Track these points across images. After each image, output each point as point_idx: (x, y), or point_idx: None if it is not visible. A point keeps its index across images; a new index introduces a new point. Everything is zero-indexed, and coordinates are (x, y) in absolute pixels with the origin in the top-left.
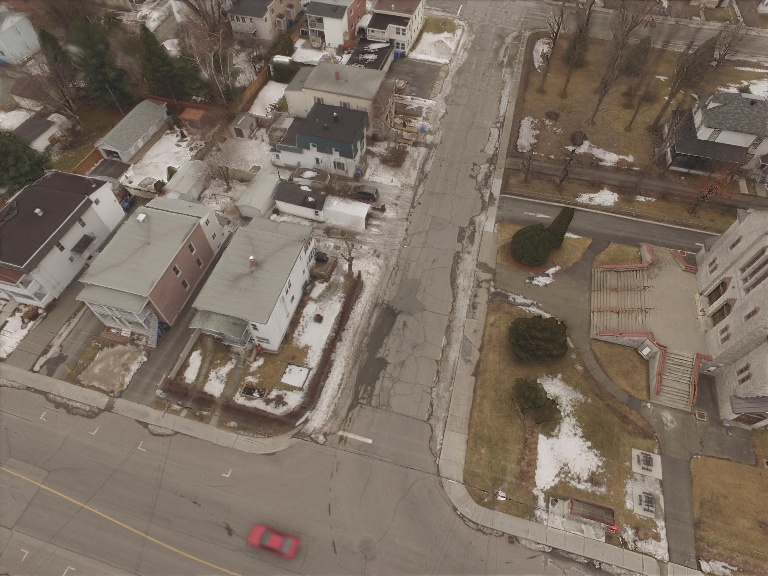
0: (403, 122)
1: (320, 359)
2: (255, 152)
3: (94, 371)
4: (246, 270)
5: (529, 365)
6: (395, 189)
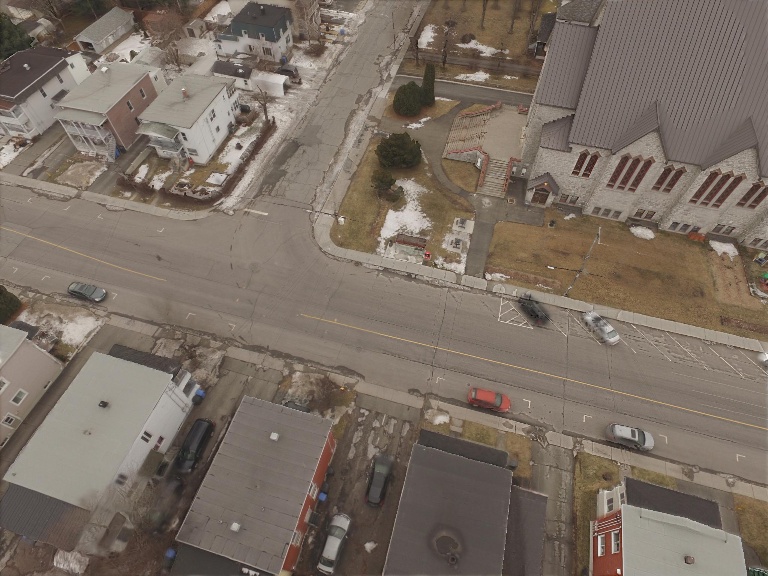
0: (326, 26)
1: (237, 170)
2: (203, 47)
3: (67, 173)
4: (180, 100)
5: (391, 172)
6: (312, 71)
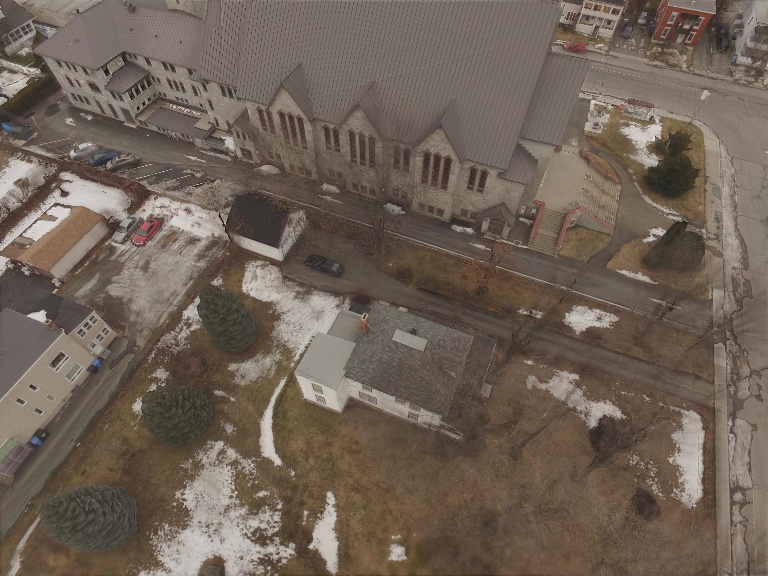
0: None
1: None
2: None
3: None
4: None
5: None
6: None
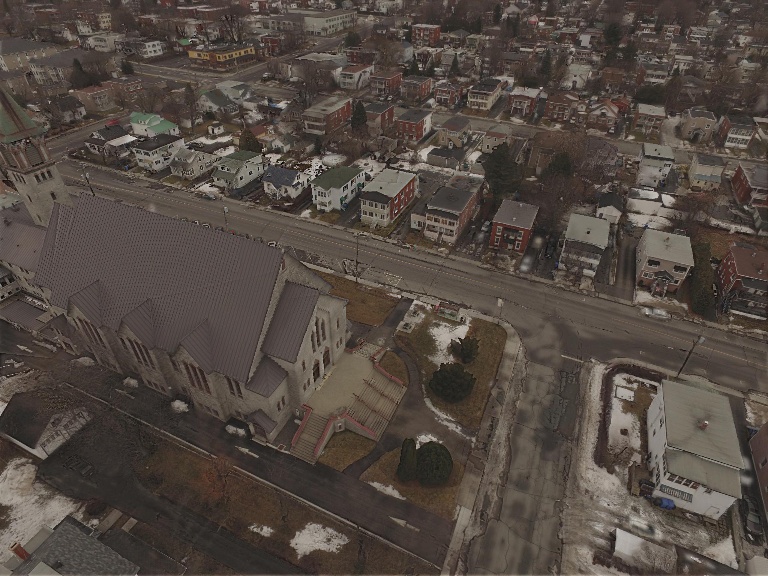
0: None
1: None
2: None
3: None
4: None
5: None
6: None
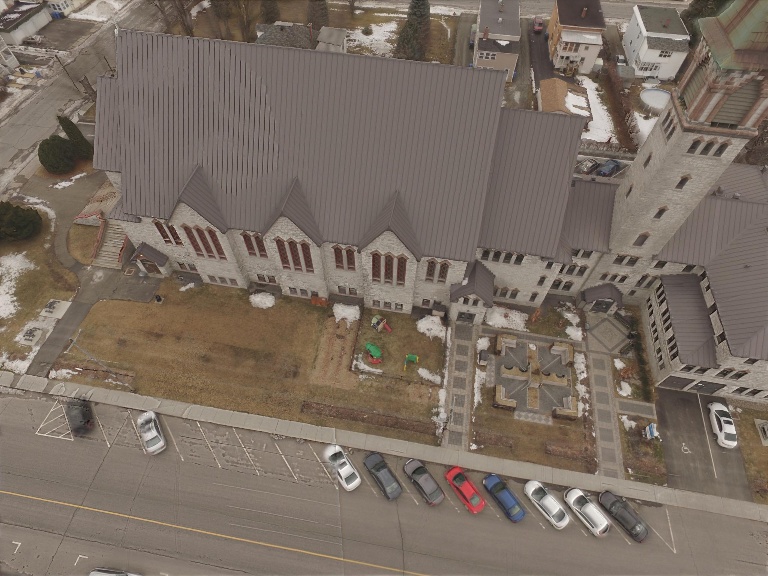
0: (19, 69)
1: None
2: None
3: None
4: None
5: (1, 247)
6: None
